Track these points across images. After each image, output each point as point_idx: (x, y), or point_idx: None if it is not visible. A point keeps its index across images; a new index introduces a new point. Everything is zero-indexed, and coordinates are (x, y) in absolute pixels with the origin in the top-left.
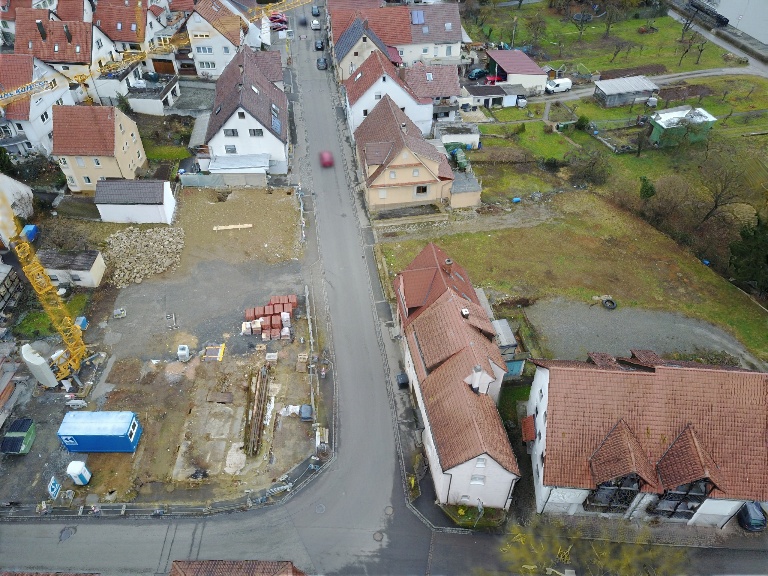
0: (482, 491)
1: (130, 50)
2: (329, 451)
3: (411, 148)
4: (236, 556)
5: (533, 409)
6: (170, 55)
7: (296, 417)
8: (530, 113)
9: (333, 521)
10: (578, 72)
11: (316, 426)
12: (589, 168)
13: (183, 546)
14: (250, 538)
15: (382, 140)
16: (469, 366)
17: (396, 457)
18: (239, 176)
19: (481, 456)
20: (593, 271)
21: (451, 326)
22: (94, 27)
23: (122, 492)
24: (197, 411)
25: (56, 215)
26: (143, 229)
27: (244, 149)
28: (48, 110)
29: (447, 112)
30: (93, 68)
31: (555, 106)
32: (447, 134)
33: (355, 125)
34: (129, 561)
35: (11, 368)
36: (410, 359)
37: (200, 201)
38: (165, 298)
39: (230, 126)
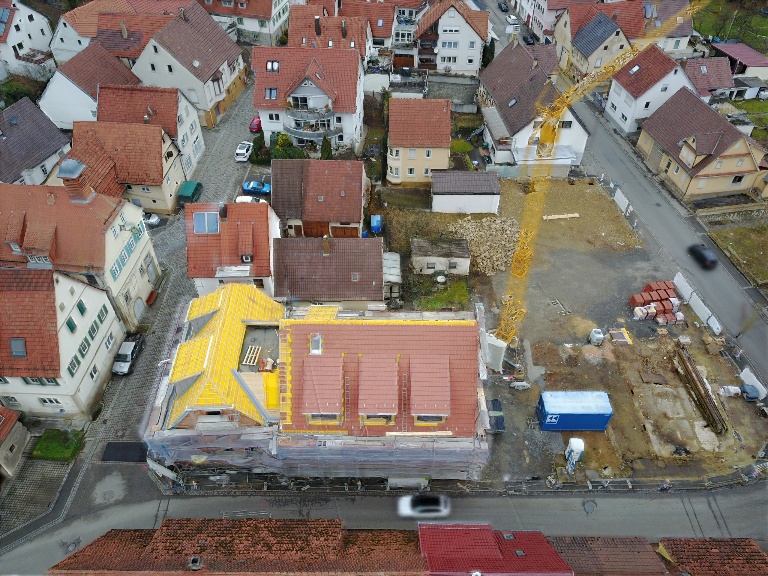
0: None
1: (373, 45)
2: None
3: None
4: (764, 528)
5: None
6: (413, 50)
7: (737, 397)
8: None
9: None
10: None
11: (761, 406)
12: None
13: (708, 518)
14: (766, 511)
15: (698, 131)
16: None
17: None
18: (543, 167)
19: None
20: None
21: None
22: (367, 22)
23: (616, 468)
24: (640, 392)
25: (387, 206)
26: (475, 219)
27: None
28: (357, 104)
29: None
30: (365, 63)
31: None
32: None
33: (634, 117)
34: (665, 532)
35: None
36: None
37: (511, 192)
38: (539, 285)
39: None
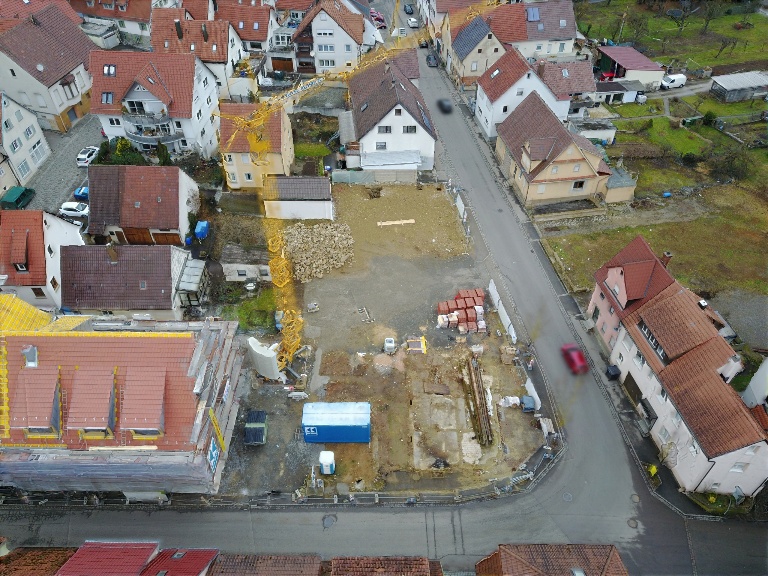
0: (738, 479)
1: (250, 49)
2: (558, 441)
3: (577, 143)
4: (500, 543)
5: (761, 399)
6: (291, 53)
7: (516, 408)
8: (652, 109)
9: (584, 509)
10: (686, 68)
11: (538, 417)
12: (728, 163)
13: (446, 533)
14: (508, 525)
15: (539, 136)
16: (723, 356)
17: (626, 447)
18: (390, 172)
19: (757, 443)
20: (765, 264)
21: (689, 317)
22: (230, 26)
23: (369, 481)
24: (418, 402)
25: (221, 211)
26: (308, 225)
27: (394, 146)
28: (202, 108)
29: (577, 108)
30: (228, 66)
31: (674, 102)
32: (586, 130)
33: (493, 121)
34: (398, 548)
35: (237, 361)
36: (628, 350)
37: (354, 197)
38: (351, 292)
39: (385, 123)
